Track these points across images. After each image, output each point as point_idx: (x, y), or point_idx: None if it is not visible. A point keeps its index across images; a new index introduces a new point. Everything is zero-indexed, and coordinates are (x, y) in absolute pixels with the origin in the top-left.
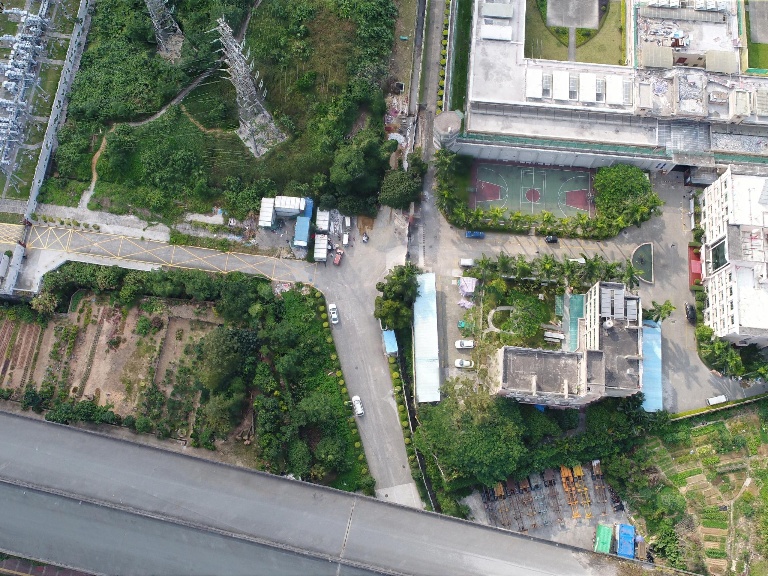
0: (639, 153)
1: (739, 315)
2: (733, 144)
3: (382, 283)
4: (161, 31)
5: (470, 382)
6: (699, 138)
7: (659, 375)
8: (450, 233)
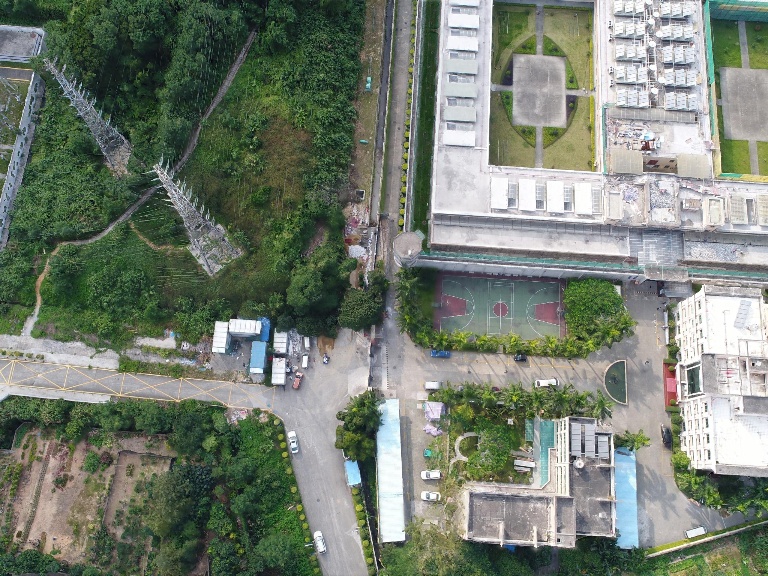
0: (610, 267)
1: (716, 451)
2: (707, 253)
3: (343, 413)
4: (105, 148)
5: (434, 531)
6: (672, 247)
7: (634, 508)
8: (414, 352)
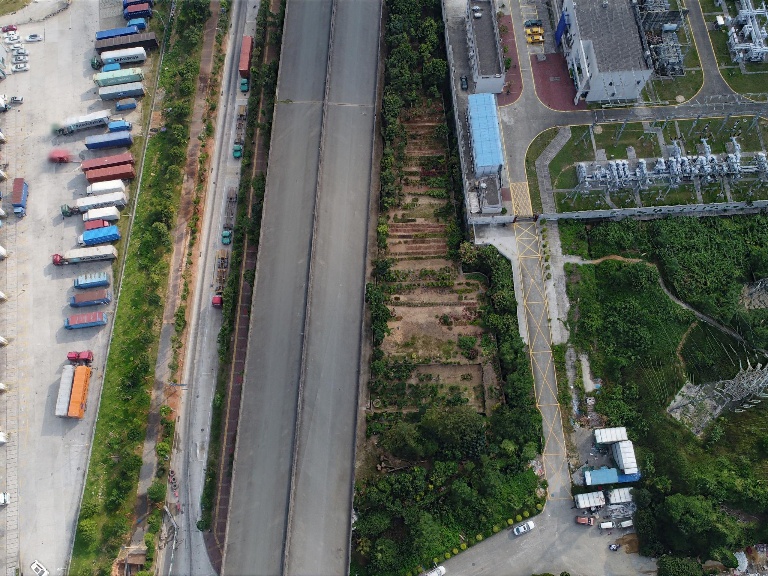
0: None
1: None
2: None
3: None
4: None
5: None
6: None
7: None
8: None
